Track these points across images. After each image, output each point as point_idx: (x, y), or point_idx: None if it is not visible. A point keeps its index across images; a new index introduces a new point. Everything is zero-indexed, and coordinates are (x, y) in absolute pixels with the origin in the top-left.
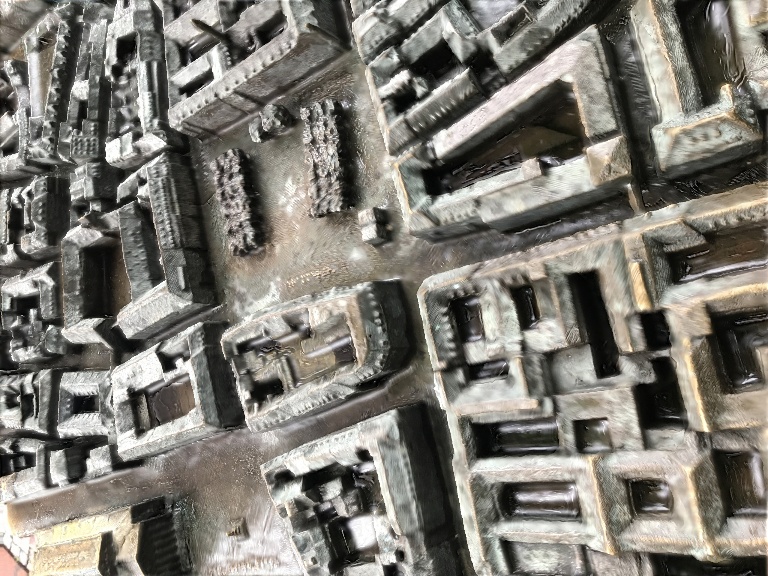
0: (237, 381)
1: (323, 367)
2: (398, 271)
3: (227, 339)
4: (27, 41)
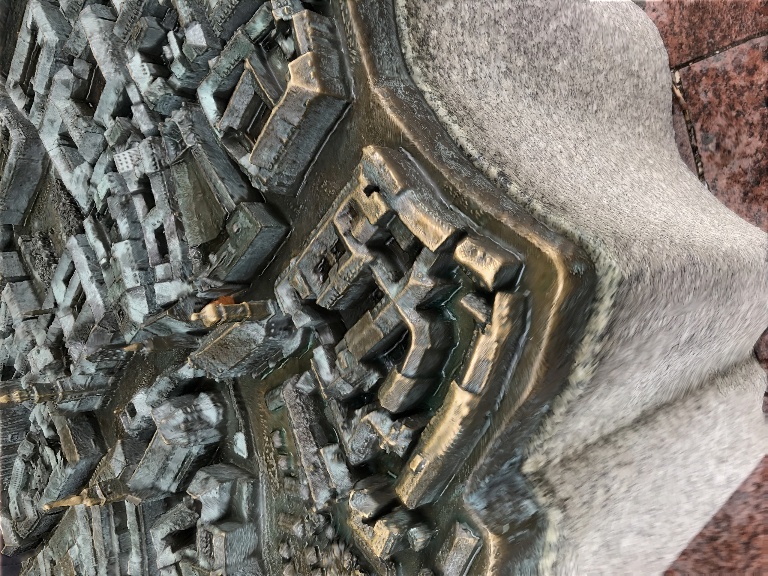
0: (7, 126)
1: (2, 168)
2: (26, 229)
3: (12, 142)
4: (233, 228)
